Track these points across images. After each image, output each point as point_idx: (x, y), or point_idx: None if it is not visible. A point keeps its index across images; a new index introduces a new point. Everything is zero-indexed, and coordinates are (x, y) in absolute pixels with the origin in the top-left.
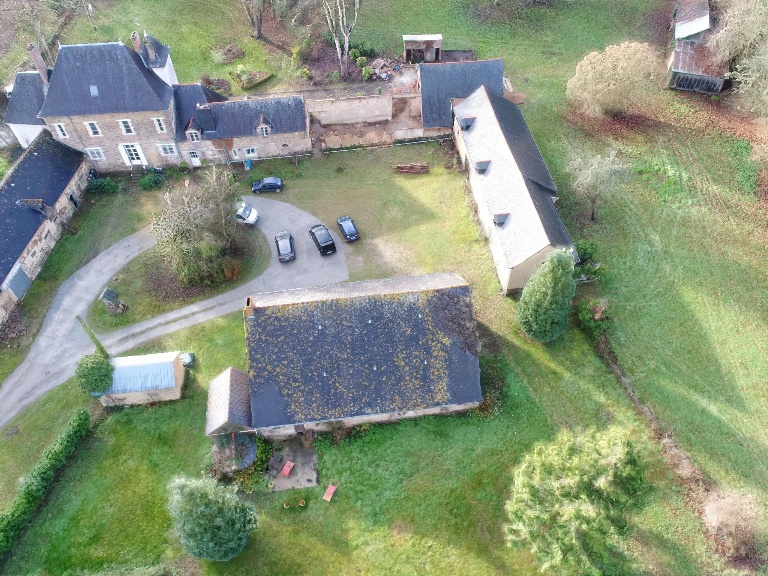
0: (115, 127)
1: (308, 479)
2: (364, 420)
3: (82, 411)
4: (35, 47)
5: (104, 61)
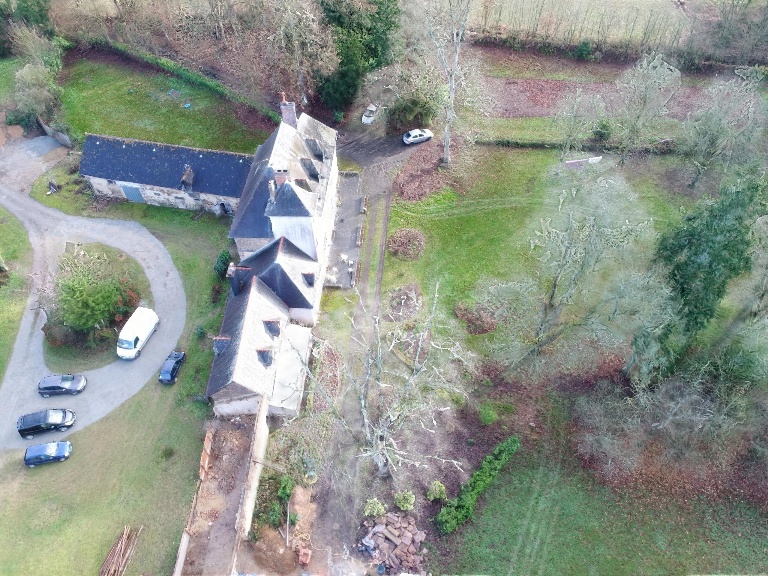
0: None
1: None
2: None
3: None
4: (291, 107)
5: None
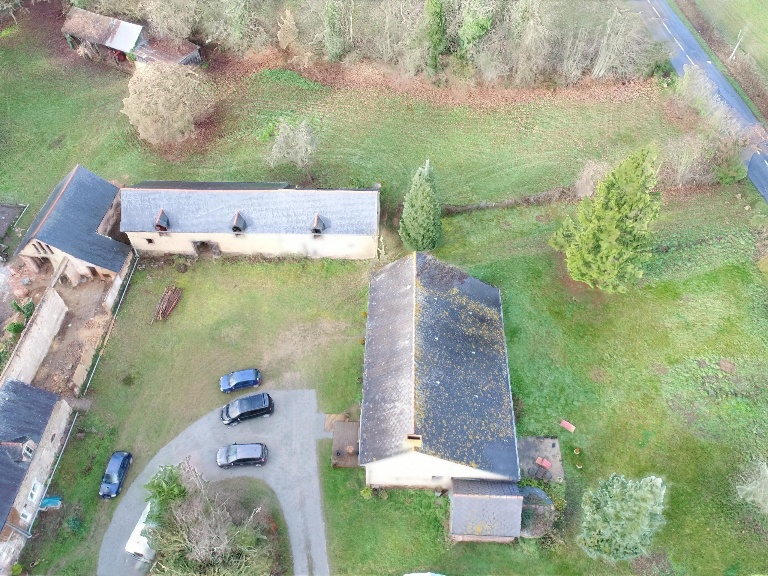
0: None
1: (552, 446)
2: None
3: None
4: None
5: None
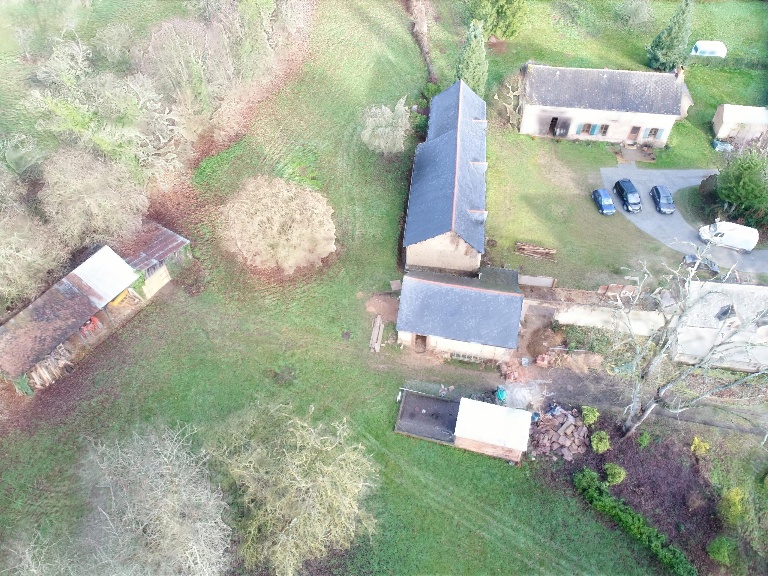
0: None
1: None
2: None
3: None
4: None
5: None
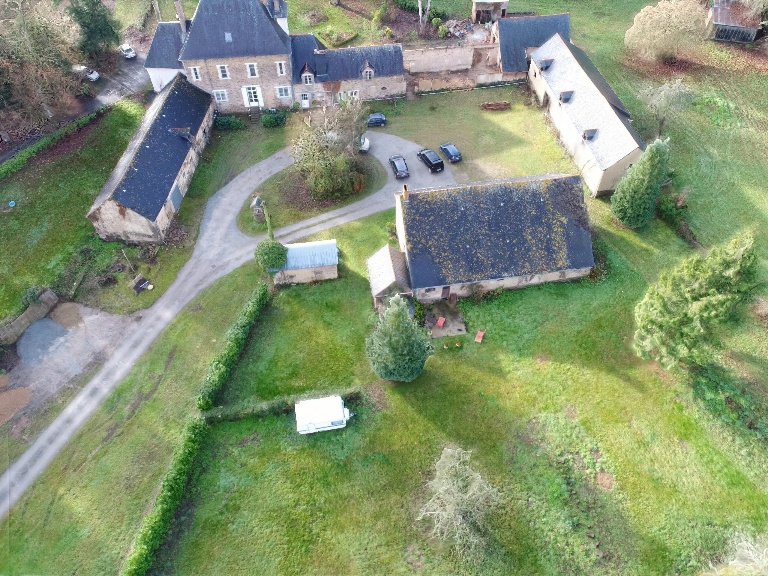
0: (242, 70)
1: (459, 329)
2: (499, 285)
3: (264, 283)
4: None
5: (238, 11)
